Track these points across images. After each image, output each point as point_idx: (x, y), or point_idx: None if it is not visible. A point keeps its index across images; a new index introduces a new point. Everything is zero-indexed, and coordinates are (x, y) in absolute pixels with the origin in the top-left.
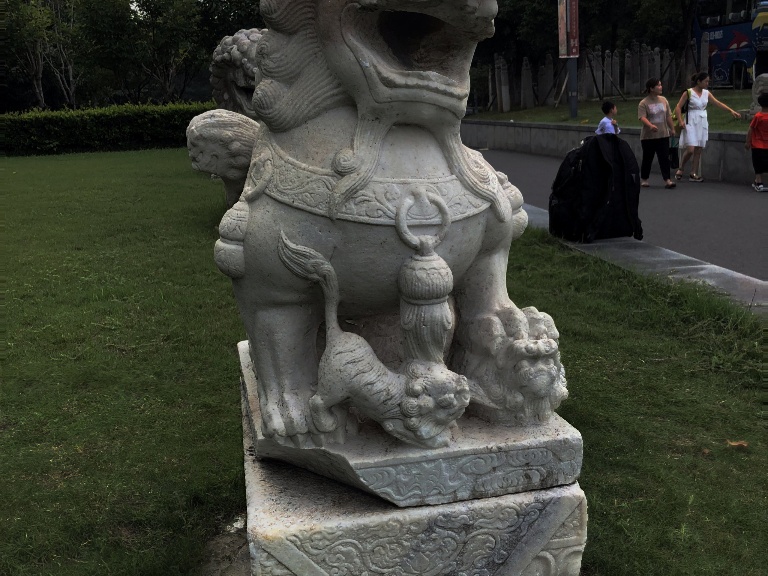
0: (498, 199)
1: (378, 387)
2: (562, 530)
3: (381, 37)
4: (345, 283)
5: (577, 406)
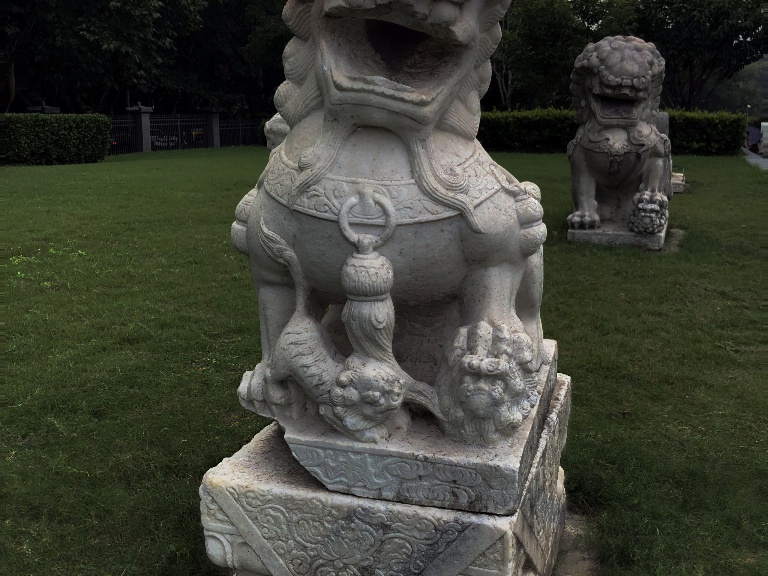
0: (470, 209)
1: (312, 371)
2: (482, 559)
3: (369, 43)
4: (308, 271)
5: None
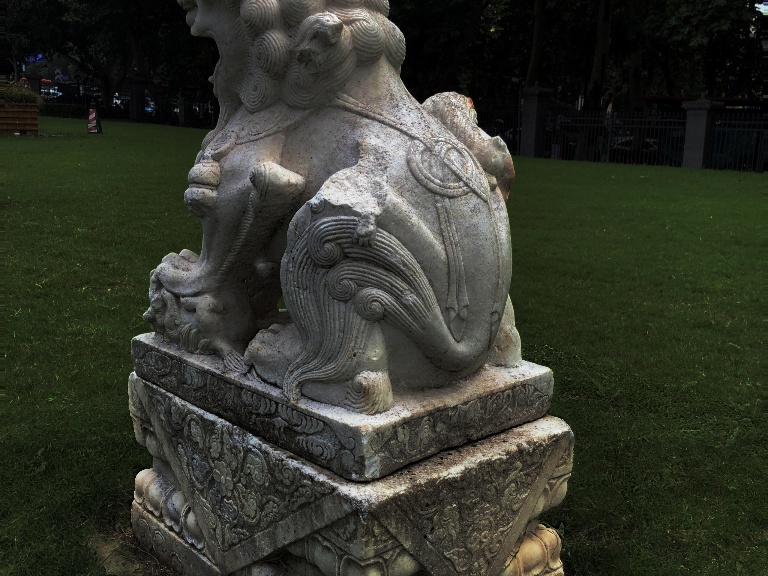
0: (196, 161)
1: None
2: None
3: None
4: None
5: None
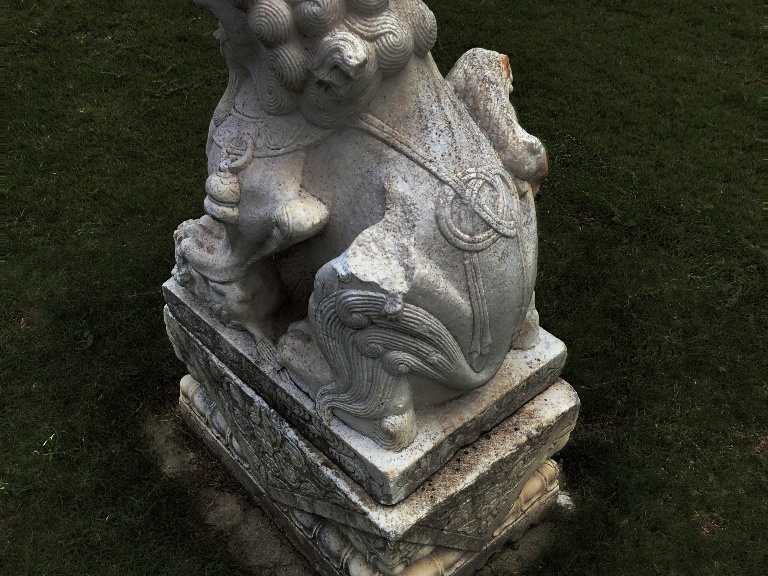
0: None
1: None
2: None
3: None
4: None
5: None
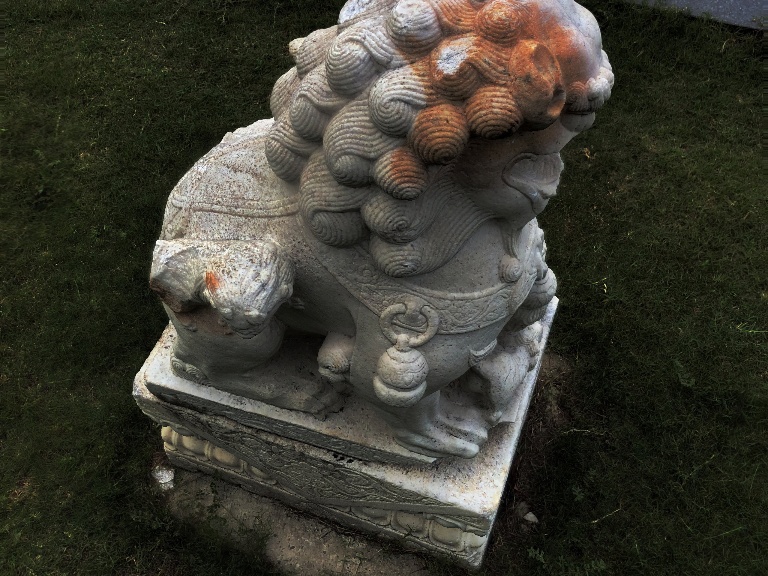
0: None
1: None
2: None
3: None
4: None
5: (207, 128)
